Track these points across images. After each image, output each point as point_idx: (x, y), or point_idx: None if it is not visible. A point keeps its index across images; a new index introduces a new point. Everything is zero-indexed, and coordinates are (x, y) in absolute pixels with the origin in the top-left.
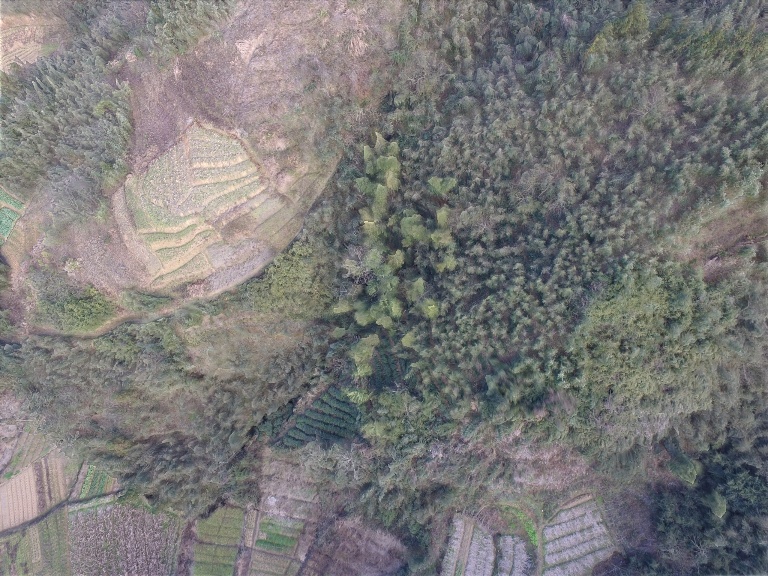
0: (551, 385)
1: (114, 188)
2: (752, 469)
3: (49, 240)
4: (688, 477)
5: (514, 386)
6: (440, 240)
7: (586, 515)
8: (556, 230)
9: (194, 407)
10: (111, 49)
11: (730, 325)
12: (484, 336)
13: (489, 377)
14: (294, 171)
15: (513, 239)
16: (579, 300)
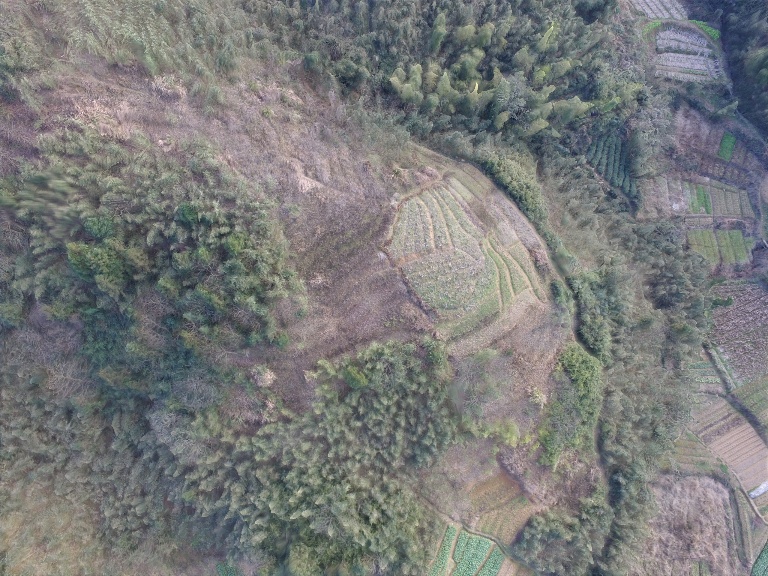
0: None
1: None
2: None
3: (517, 428)
4: None
5: None
6: (492, 28)
7: None
8: None
9: None
10: (237, 430)
11: None
12: (560, 7)
13: (591, 1)
14: None
15: None
16: None
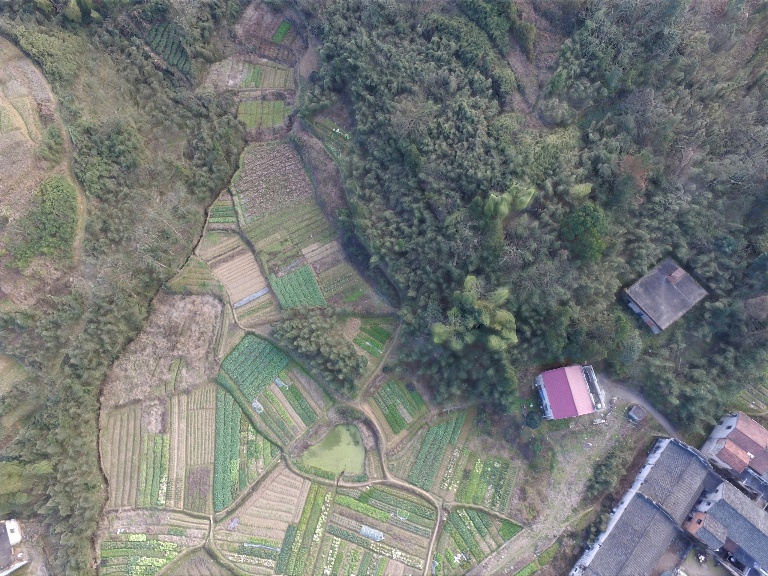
0: None
1: None
2: None
3: None
4: None
5: None
6: None
7: None
8: None
9: None
10: None
11: None
12: None
13: None
14: None
15: None
16: None
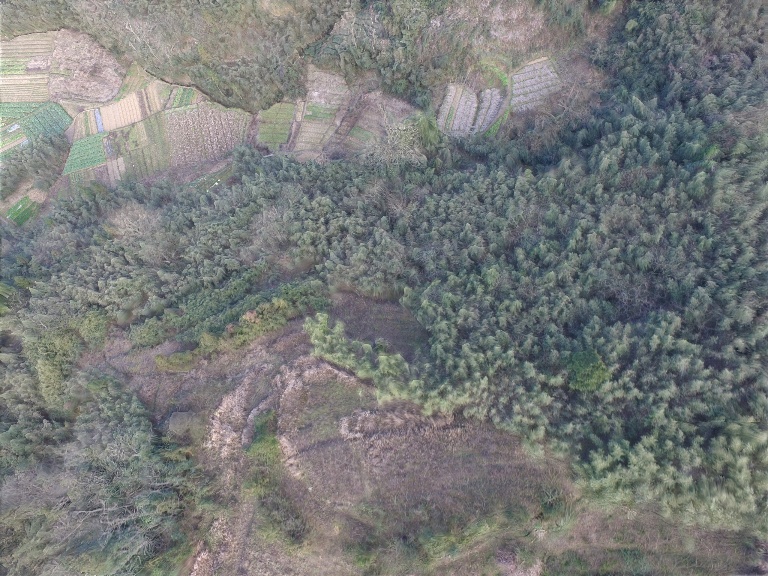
0: None
1: None
2: None
3: None
4: (610, 2)
5: None
6: None
7: (543, 68)
8: None
9: None
10: None
11: None
12: None
13: None
14: None
15: None
16: None
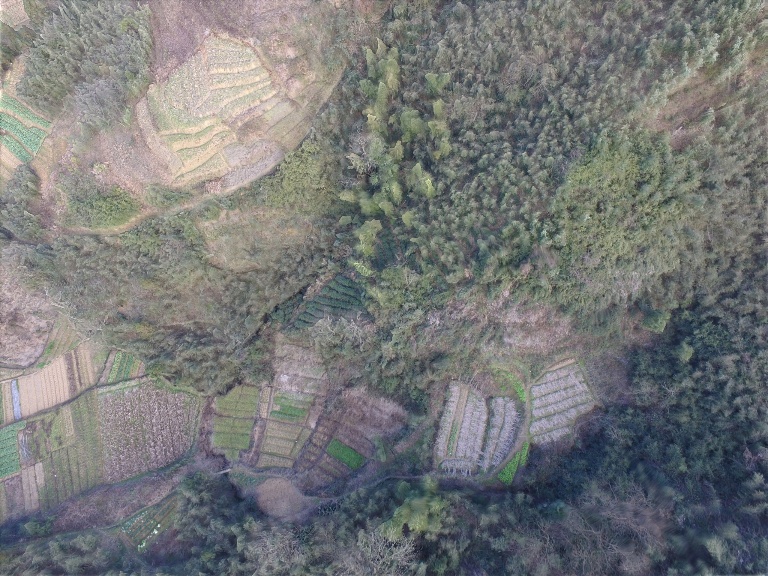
0: (535, 242)
1: (137, 99)
2: (715, 319)
3: (78, 145)
4: (658, 326)
5: (503, 247)
6: (436, 127)
7: (569, 376)
8: (540, 111)
9: (212, 296)
10: None
11: (694, 186)
12: (476, 208)
13: (480, 240)
14: (303, 78)
15: (502, 127)
16: (560, 166)
